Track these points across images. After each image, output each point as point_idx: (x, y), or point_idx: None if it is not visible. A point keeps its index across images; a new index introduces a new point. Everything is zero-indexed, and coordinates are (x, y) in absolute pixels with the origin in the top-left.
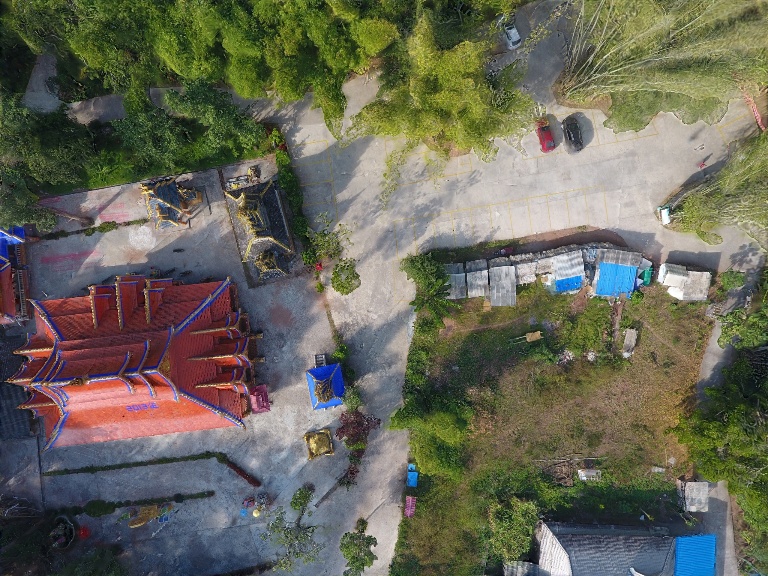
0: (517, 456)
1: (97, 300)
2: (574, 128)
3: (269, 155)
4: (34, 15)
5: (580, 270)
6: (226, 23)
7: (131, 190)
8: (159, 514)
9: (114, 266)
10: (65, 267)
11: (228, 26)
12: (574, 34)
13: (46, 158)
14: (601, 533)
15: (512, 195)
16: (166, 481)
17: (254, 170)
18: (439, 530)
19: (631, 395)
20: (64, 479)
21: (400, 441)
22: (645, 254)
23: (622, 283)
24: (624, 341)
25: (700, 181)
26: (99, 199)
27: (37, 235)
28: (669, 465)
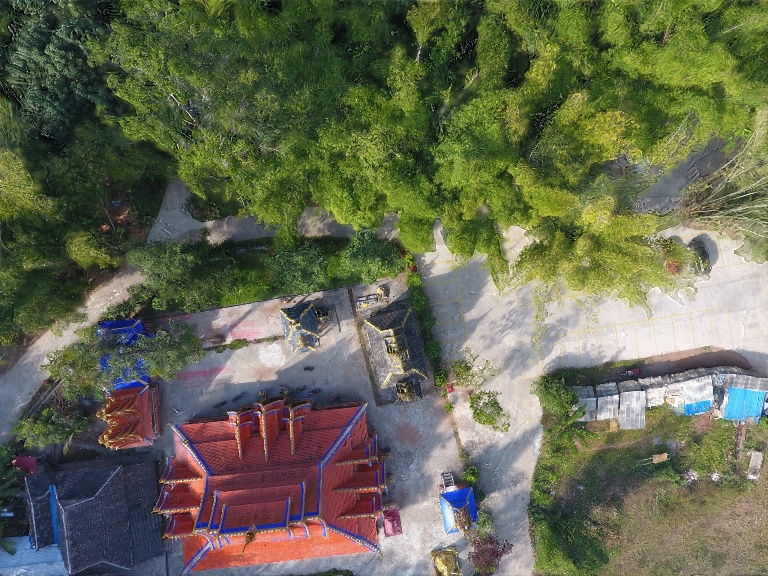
0: None
1: (241, 430)
2: (702, 252)
3: (398, 274)
4: (204, 166)
5: (709, 395)
6: (412, 193)
7: (262, 308)
8: None
9: (244, 383)
10: (196, 384)
11: None
12: None
13: None
14: None
15: (638, 316)
16: None
17: (384, 289)
18: None
19: (755, 516)
20: None
21: (525, 560)
22: None
23: (750, 407)
24: (750, 463)
25: None
26: (230, 316)
27: None
28: None
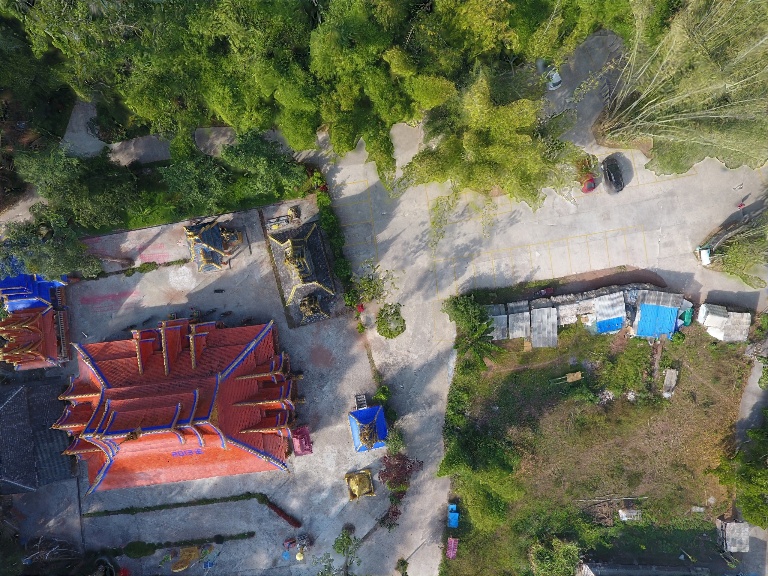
0: (557, 496)
1: (142, 345)
2: (615, 169)
3: (309, 195)
4: None
5: (621, 311)
6: (284, 80)
7: (171, 230)
8: (201, 557)
9: (154, 307)
10: (105, 308)
11: (286, 83)
12: (619, 80)
13: (91, 203)
14: (643, 574)
15: (552, 235)
16: (206, 522)
17: (295, 210)
18: (480, 571)
19: (671, 435)
20: (104, 520)
21: (440, 481)
22: (684, 294)
23: (663, 324)
24: (664, 381)
25: (739, 221)
26: (139, 239)
27: (77, 276)
28: (709, 505)
